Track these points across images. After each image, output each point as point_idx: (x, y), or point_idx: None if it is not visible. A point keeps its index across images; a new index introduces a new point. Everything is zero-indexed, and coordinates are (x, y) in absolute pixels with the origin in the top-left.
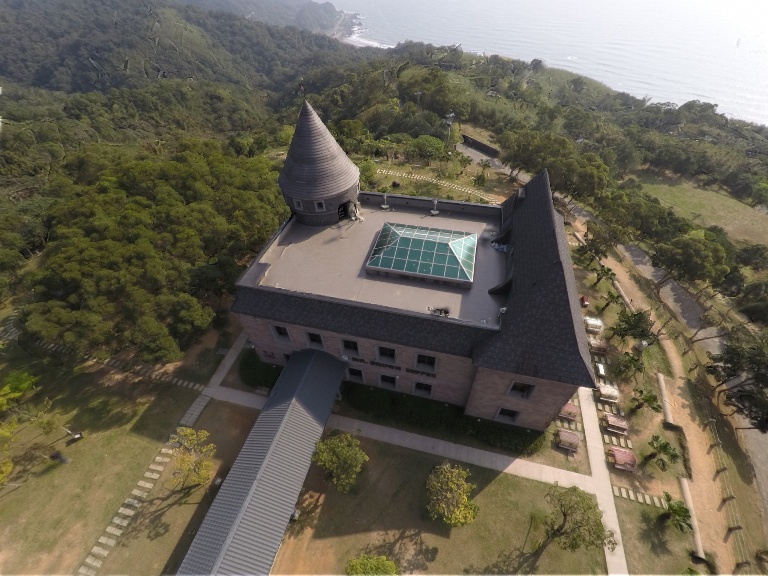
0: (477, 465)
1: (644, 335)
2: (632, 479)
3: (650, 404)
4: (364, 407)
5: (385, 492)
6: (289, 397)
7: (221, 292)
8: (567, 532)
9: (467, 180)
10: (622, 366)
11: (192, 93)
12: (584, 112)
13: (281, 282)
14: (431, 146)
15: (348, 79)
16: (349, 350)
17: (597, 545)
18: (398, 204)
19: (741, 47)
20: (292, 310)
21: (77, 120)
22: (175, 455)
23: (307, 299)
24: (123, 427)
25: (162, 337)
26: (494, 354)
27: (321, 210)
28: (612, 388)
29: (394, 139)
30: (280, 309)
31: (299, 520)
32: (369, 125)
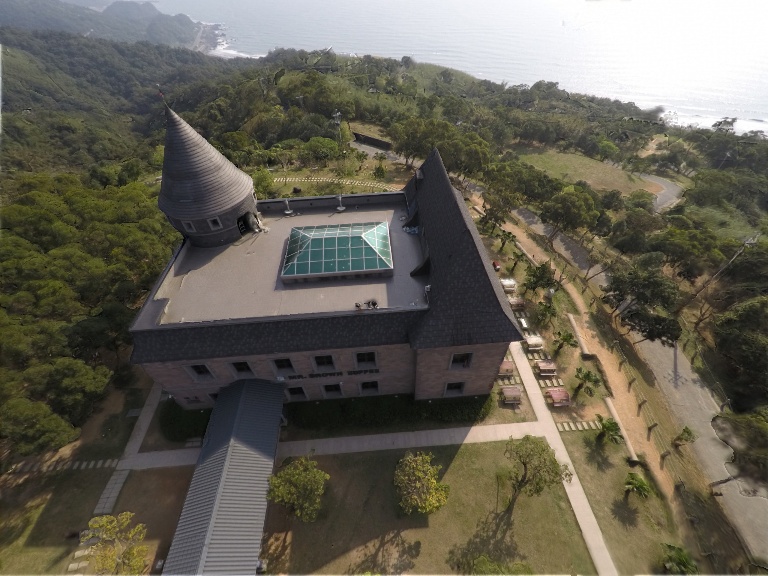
0: (438, 445)
1: (550, 283)
2: (570, 412)
3: (568, 342)
4: (314, 424)
5: (355, 505)
6: (225, 440)
7: (115, 345)
8: (530, 479)
9: (367, 174)
10: (539, 315)
11: (32, 127)
12: (457, 99)
13: (187, 315)
14: (324, 147)
15: (223, 92)
16: (283, 369)
17: (557, 482)
18: (302, 207)
19: (566, 27)
20: (207, 343)
21: None
22: (92, 555)
23: (221, 326)
24: (12, 545)
25: (43, 418)
26: (429, 333)
27: (217, 228)
28: (536, 337)
29: (285, 146)
30: (192, 346)
31: (268, 570)
32: (256, 135)
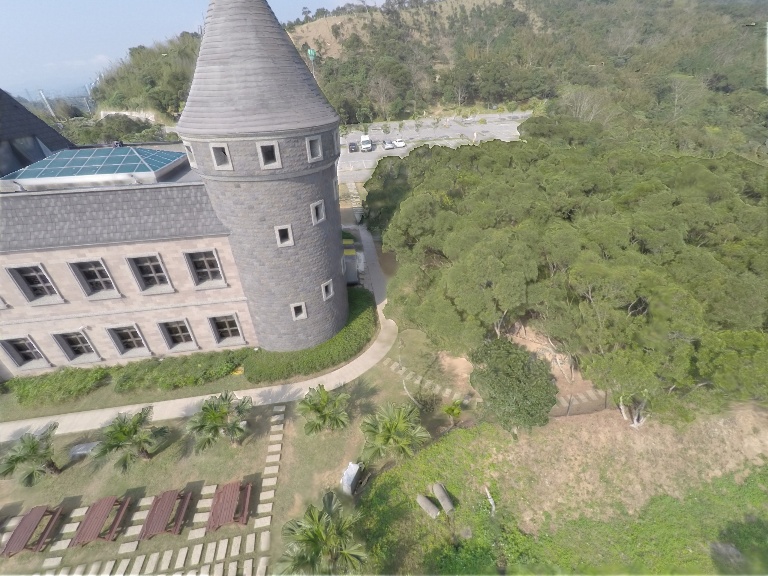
0: None
1: None
2: None
3: None
4: None
5: None
6: None
7: None
8: None
9: None
10: None
11: None
12: None
13: None
14: None
15: None
16: None
17: None
18: None
19: None
20: None
21: None
22: None
23: None
24: None
25: None
26: None
27: None
28: None
29: None
30: None
31: None
32: None
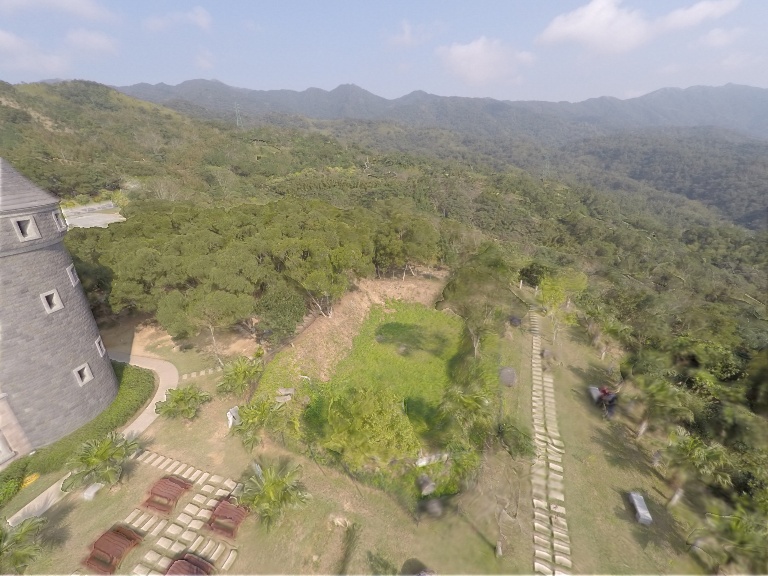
0: None
1: None
2: None
3: None
4: None
5: None
6: None
7: None
8: None
9: None
10: None
11: None
12: None
13: None
14: None
15: None
16: None
17: None
18: None
19: None
20: None
21: (685, 244)
22: None
23: None
24: None
25: None
26: None
27: None
28: None
29: None
30: None
31: None
32: None
